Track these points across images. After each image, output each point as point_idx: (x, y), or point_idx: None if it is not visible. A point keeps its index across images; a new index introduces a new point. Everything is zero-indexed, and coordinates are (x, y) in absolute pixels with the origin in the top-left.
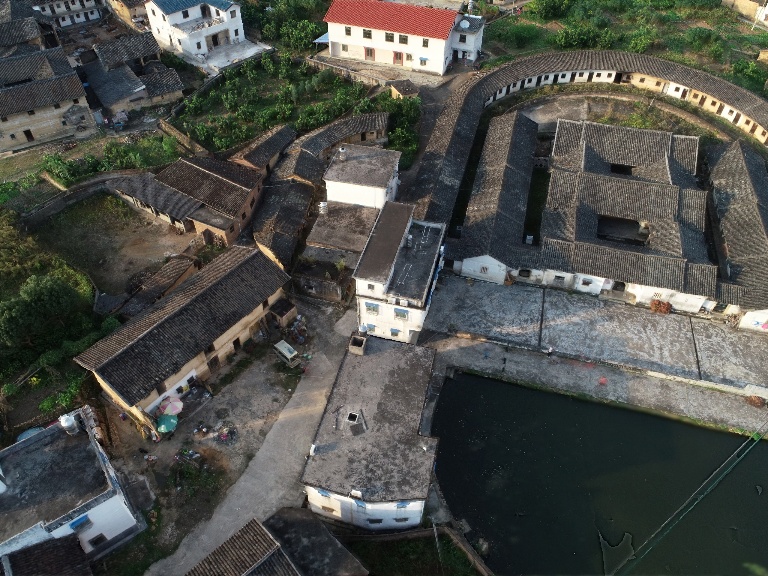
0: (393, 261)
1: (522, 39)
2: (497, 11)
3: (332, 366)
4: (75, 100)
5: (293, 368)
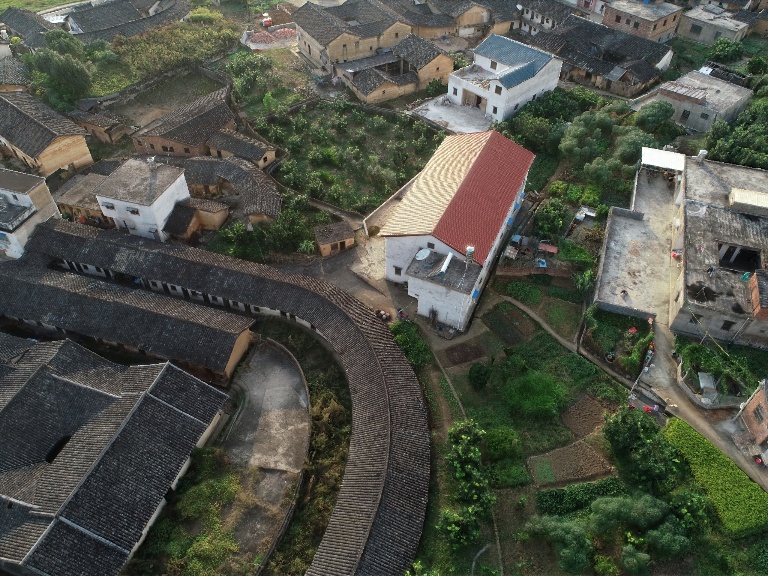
0: None
1: (472, 372)
2: (622, 361)
3: None
4: None
5: None
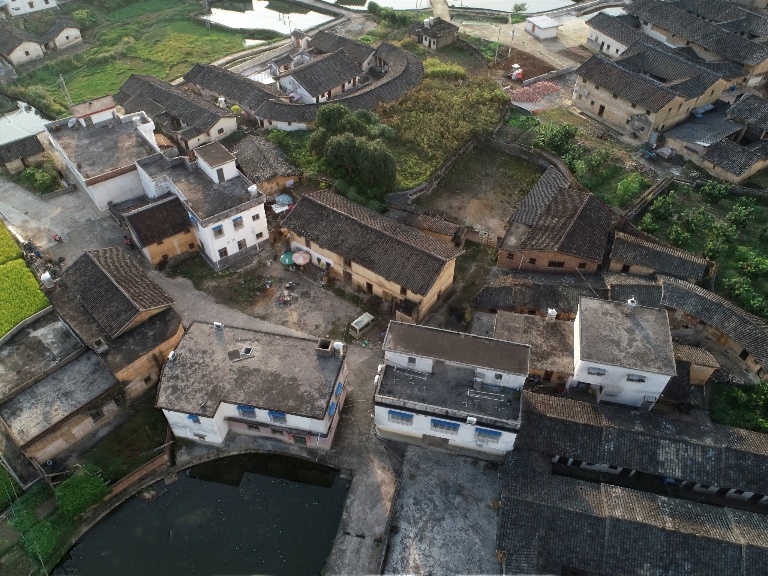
0: (418, 354)
1: None
2: None
3: (354, 365)
4: (649, 111)
5: (350, 334)
